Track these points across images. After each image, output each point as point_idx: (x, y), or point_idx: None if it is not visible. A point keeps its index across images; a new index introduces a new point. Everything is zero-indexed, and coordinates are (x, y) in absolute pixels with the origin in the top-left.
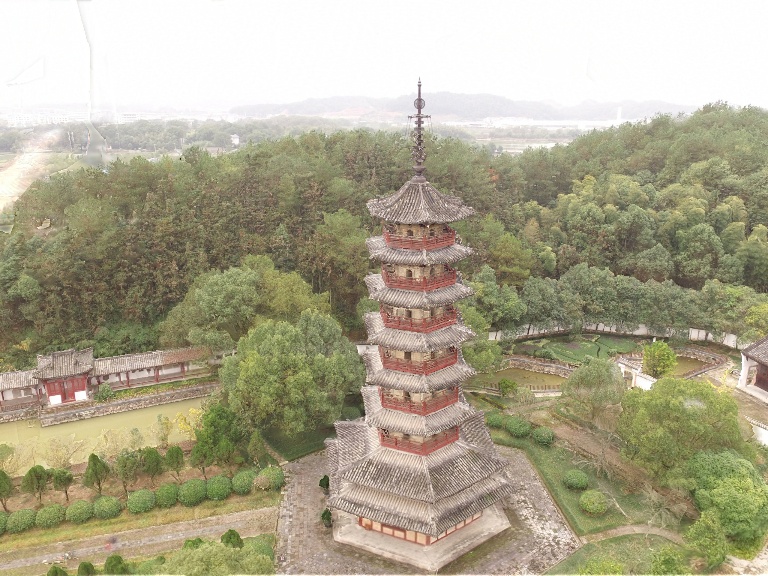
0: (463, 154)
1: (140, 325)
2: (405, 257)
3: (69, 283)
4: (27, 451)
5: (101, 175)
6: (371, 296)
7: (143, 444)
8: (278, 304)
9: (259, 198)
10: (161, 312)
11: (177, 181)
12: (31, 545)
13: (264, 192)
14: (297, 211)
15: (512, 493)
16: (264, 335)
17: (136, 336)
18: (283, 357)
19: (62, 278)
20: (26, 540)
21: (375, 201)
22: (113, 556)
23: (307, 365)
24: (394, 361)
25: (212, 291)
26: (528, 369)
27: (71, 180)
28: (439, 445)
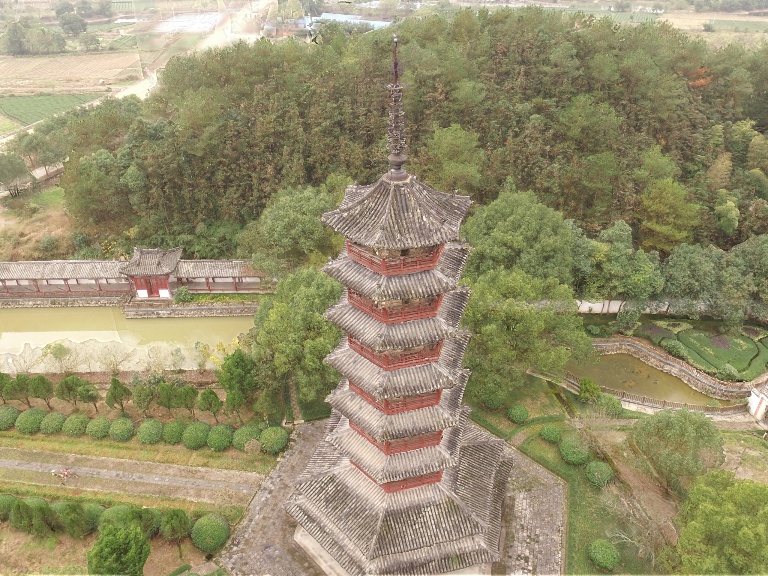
0: (660, 48)
1: (238, 225)
2: (361, 278)
3: (170, 178)
4: (84, 351)
5: (229, 56)
6: (325, 313)
7: (184, 365)
8: (337, 242)
9: (374, 98)
10: (258, 215)
11: (293, 71)
12: (52, 450)
13: (381, 91)
14: (418, 115)
15: (518, 541)
16: (303, 282)
17: (233, 236)
18: (309, 315)
19: (165, 172)
20: (51, 443)
21: (354, 188)
22: (70, 504)
23: (334, 328)
24: (358, 387)
25: (278, 215)
26: (644, 360)
27: (195, 62)
28: (410, 485)
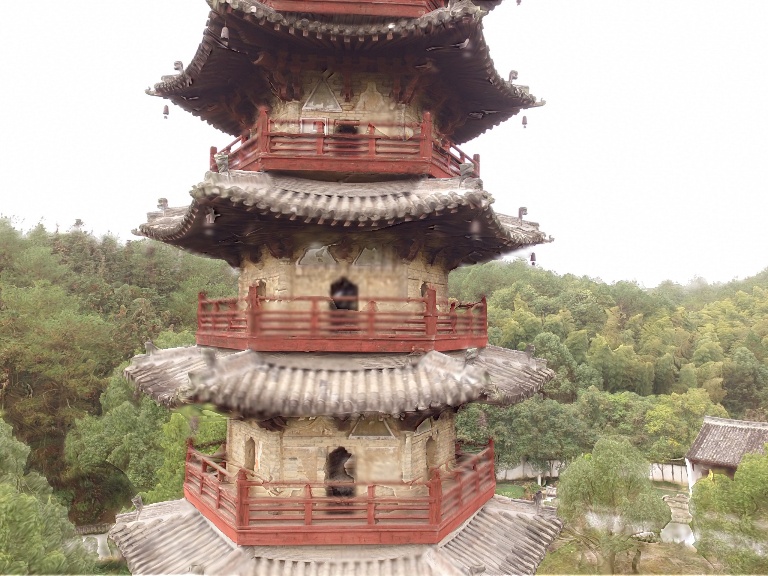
0: None
1: None
2: None
3: None
4: None
5: None
6: None
7: None
8: None
9: None
10: None
11: None
12: None
13: None
14: None
15: None
16: None
17: None
18: None
19: None
20: None
21: None
22: None
23: None
24: (299, 311)
25: None
26: None
27: None
28: None
